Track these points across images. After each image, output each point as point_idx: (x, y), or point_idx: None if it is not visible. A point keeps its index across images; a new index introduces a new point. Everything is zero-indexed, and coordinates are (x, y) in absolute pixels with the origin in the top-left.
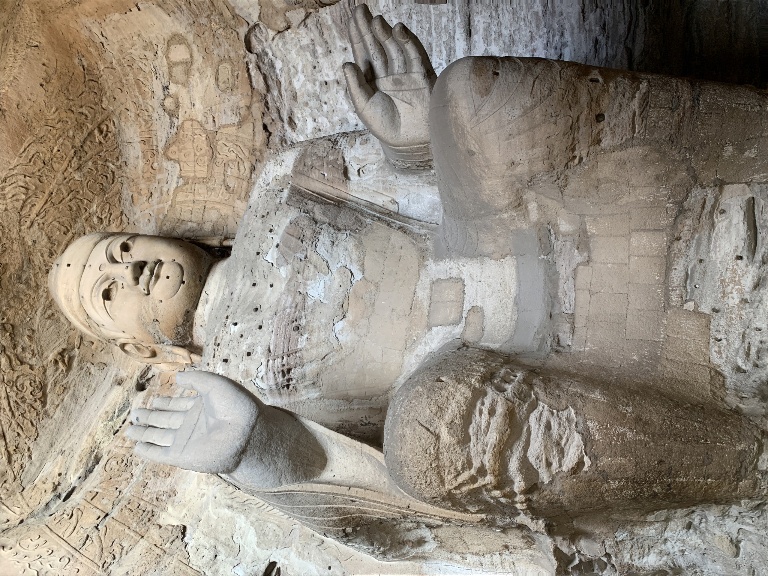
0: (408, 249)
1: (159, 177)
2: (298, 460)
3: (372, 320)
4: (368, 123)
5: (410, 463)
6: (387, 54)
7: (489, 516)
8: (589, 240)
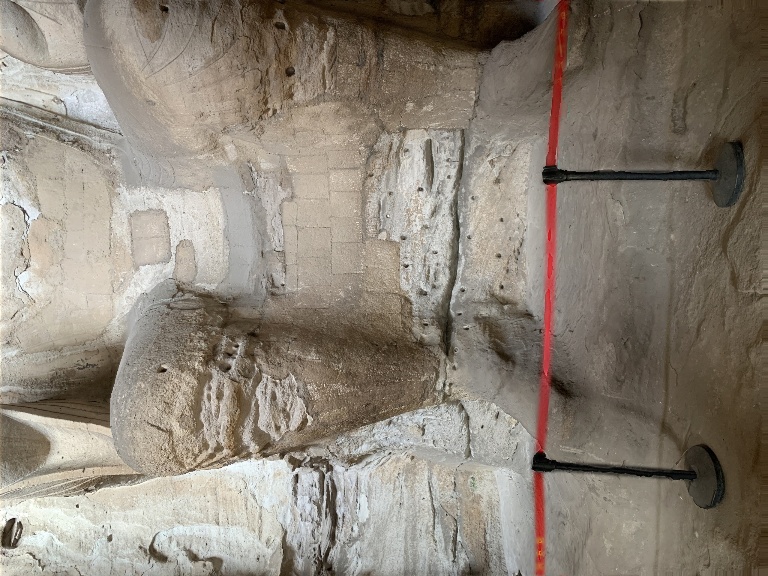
0: (91, 173)
1: None
2: (15, 457)
3: (65, 266)
4: None
5: (146, 461)
6: None
7: None
8: (291, 177)
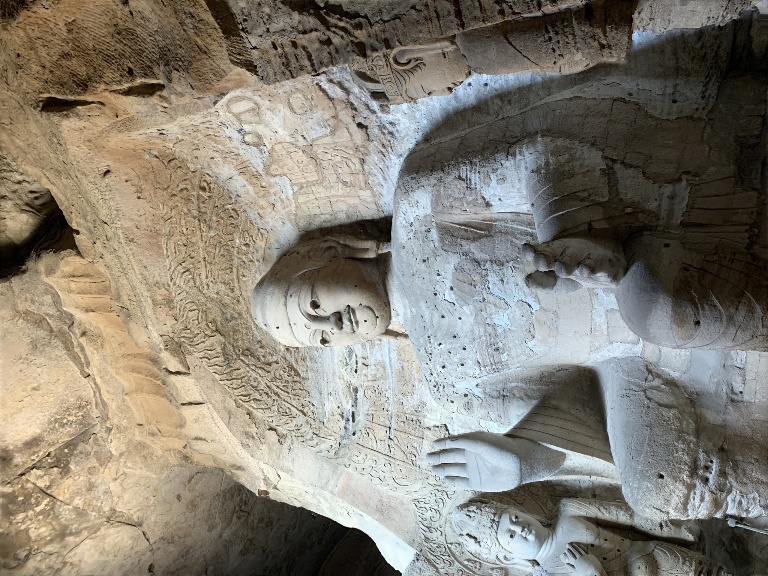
0: None
1: (273, 191)
2: (550, 466)
3: (558, 338)
4: None
5: None
6: None
7: None
8: None
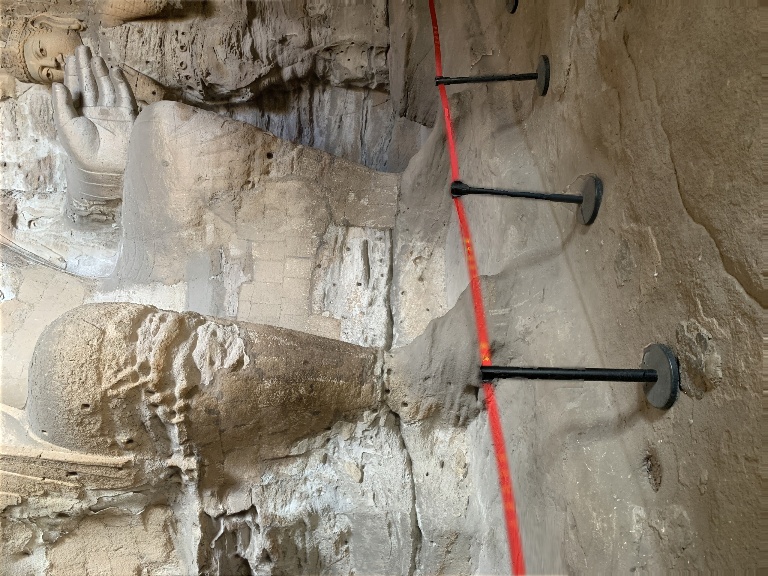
0: (74, 284)
1: None
2: None
3: (18, 334)
4: (67, 137)
5: (66, 356)
6: (99, 91)
7: (138, 457)
8: (253, 263)
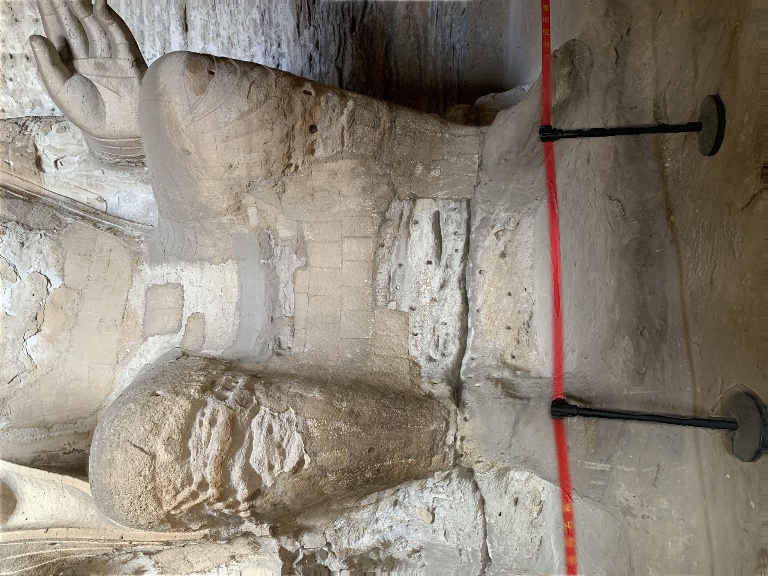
0: (119, 252)
1: None
2: None
3: (75, 333)
4: (65, 108)
5: (121, 490)
6: (87, 33)
7: (213, 530)
8: (306, 245)
